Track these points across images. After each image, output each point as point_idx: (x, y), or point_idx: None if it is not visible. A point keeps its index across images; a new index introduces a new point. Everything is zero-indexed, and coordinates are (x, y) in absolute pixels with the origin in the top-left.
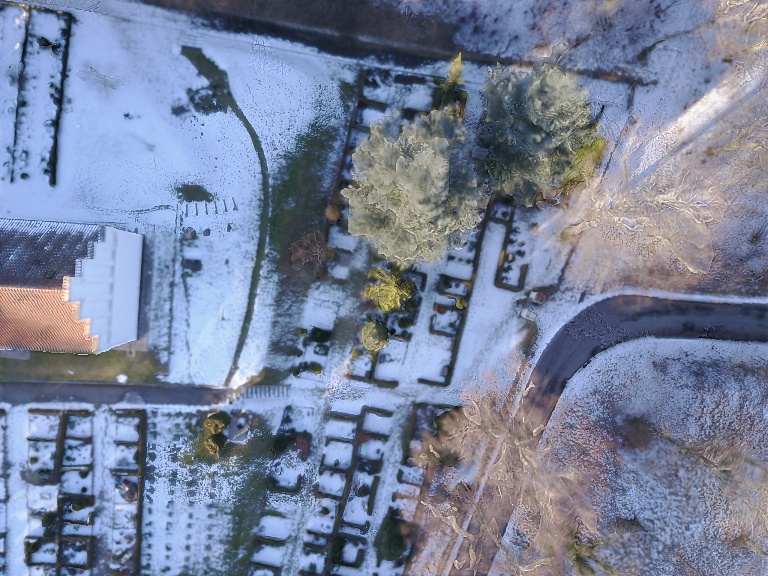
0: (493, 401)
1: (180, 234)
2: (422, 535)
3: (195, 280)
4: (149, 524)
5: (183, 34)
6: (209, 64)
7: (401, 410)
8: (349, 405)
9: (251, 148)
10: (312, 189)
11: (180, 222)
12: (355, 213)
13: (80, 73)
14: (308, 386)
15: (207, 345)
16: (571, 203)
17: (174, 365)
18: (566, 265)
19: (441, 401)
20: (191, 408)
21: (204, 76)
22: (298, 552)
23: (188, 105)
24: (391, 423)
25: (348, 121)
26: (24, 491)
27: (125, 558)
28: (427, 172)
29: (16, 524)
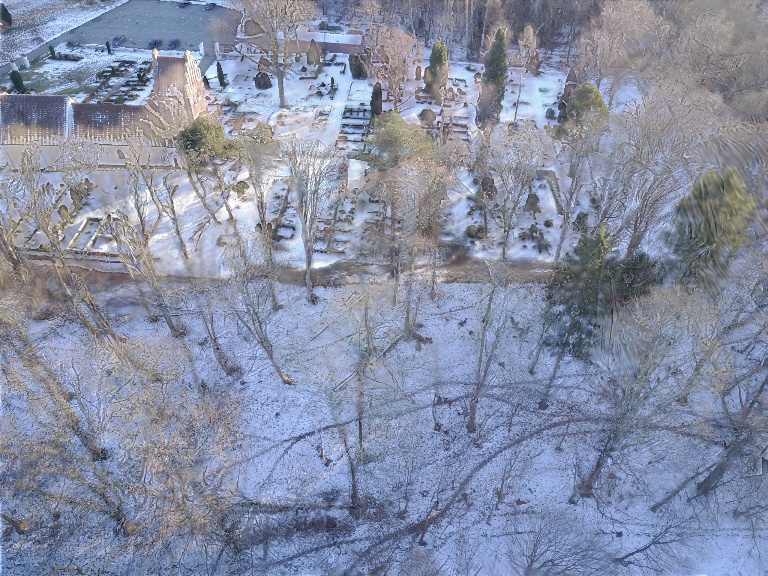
0: None
1: None
2: None
3: None
4: None
5: None
6: None
7: None
8: None
9: None
10: None
11: None
12: None
13: None
14: None
15: None
16: None
17: None
18: None
19: None
20: None
21: None
22: None
23: None
24: None
25: None
26: None
27: None
28: None
29: (137, 103)
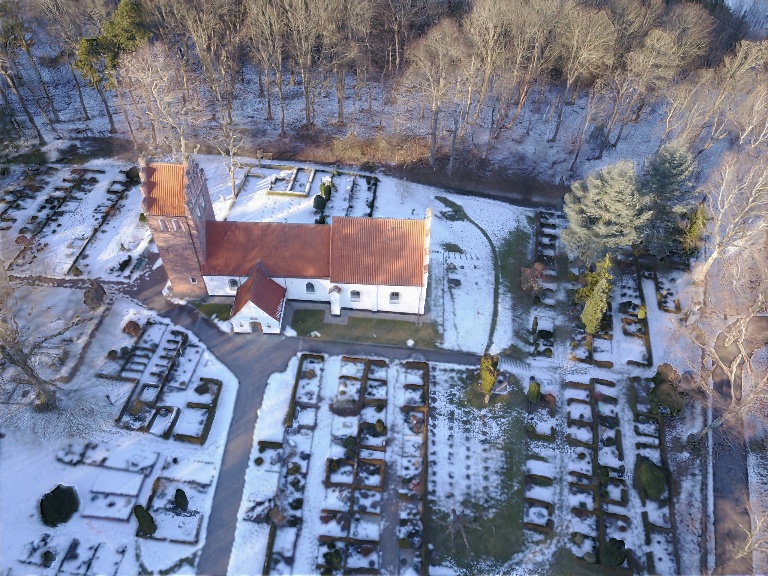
0: (691, 376)
1: (446, 266)
2: (674, 479)
3: (457, 291)
4: (433, 454)
5: (434, 193)
6: (451, 203)
7: (621, 383)
8: (579, 378)
9: (482, 235)
10: (522, 257)
11: (445, 261)
12: (573, 221)
13: (396, 183)
14: (544, 365)
15: (469, 327)
16: (691, 268)
17: (447, 338)
18: (705, 298)
19: (650, 377)
20: (461, 366)
21: (449, 207)
22: (566, 492)
23: (442, 217)
24: (616, 392)
25: (534, 233)
26: (330, 420)
27: (413, 483)
28: (621, 171)
29: (319, 449)
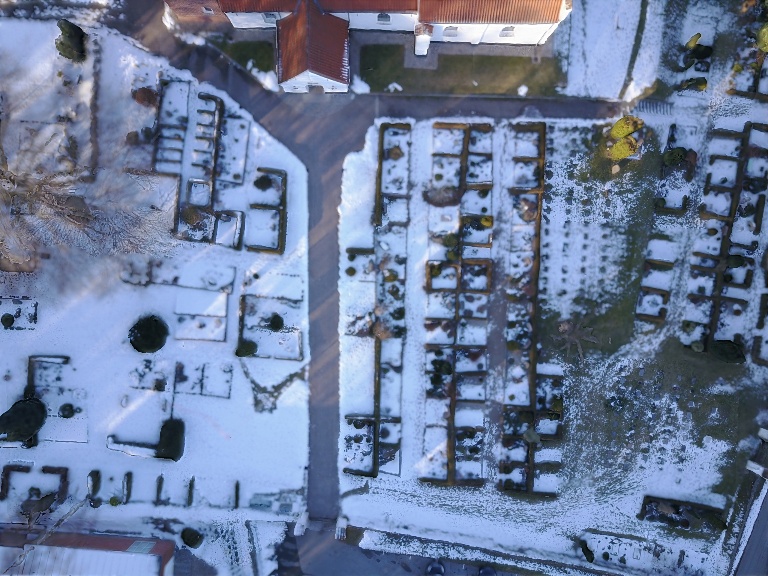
0: None
1: None
2: None
3: None
4: (546, 246)
5: None
6: None
7: None
8: (732, 122)
9: None
10: None
11: None
12: None
13: None
14: (691, 104)
15: (603, 55)
16: None
17: (571, 77)
18: None
19: None
20: (587, 122)
21: None
22: (686, 276)
23: None
24: None
25: None
26: (425, 213)
27: (522, 282)
28: None
29: (416, 249)
